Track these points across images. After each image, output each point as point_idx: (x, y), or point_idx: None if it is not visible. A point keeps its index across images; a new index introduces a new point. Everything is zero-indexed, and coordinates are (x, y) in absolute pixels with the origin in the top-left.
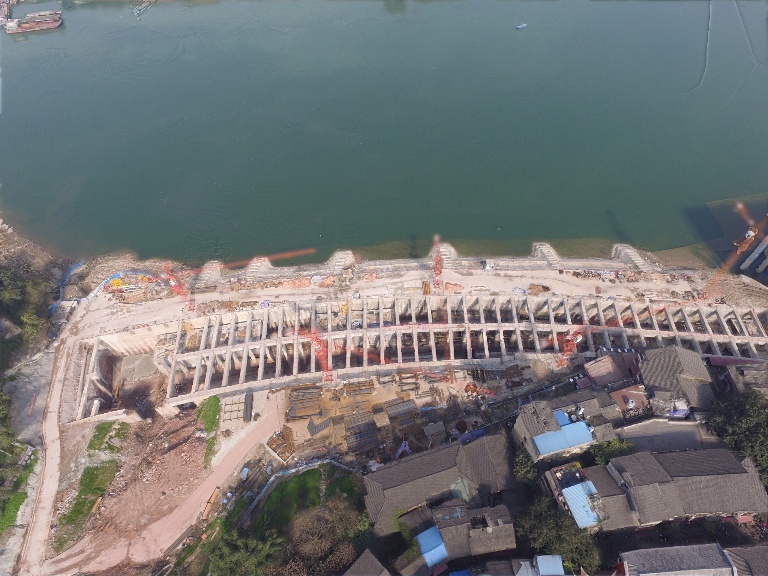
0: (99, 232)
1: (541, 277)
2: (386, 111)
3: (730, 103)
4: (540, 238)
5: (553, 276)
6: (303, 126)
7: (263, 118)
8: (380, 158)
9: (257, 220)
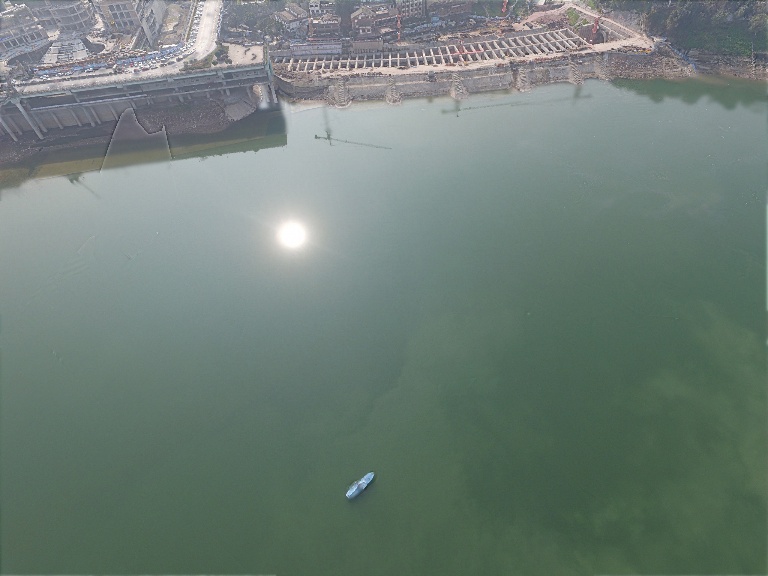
0: (715, 88)
1: (402, 72)
2: (560, 202)
3: (135, 249)
4: (395, 108)
5: (395, 73)
6: (647, 180)
7: (710, 192)
8: (536, 150)
9: (605, 103)
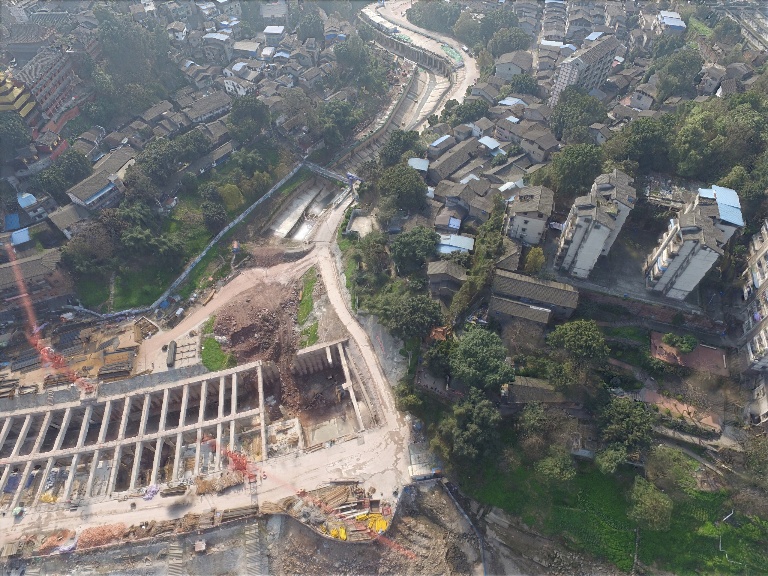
0: None
1: None
2: None
3: None
4: None
5: None
6: None
7: None
8: None
9: None
